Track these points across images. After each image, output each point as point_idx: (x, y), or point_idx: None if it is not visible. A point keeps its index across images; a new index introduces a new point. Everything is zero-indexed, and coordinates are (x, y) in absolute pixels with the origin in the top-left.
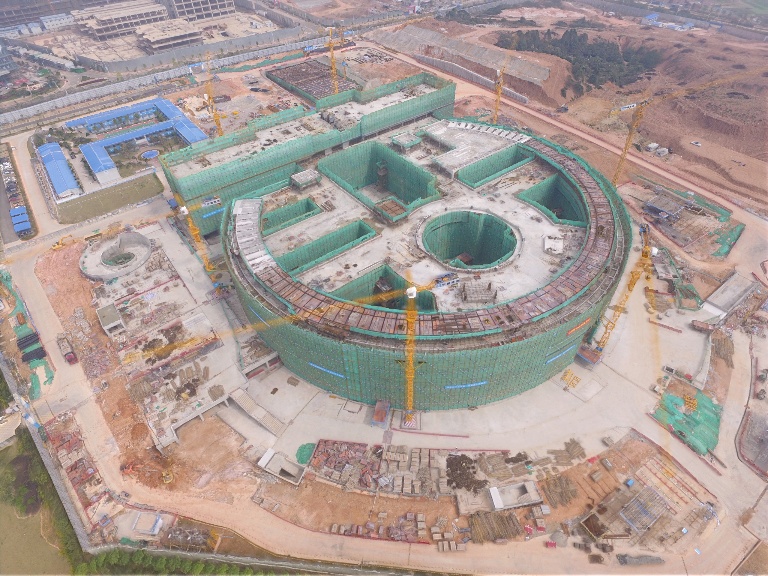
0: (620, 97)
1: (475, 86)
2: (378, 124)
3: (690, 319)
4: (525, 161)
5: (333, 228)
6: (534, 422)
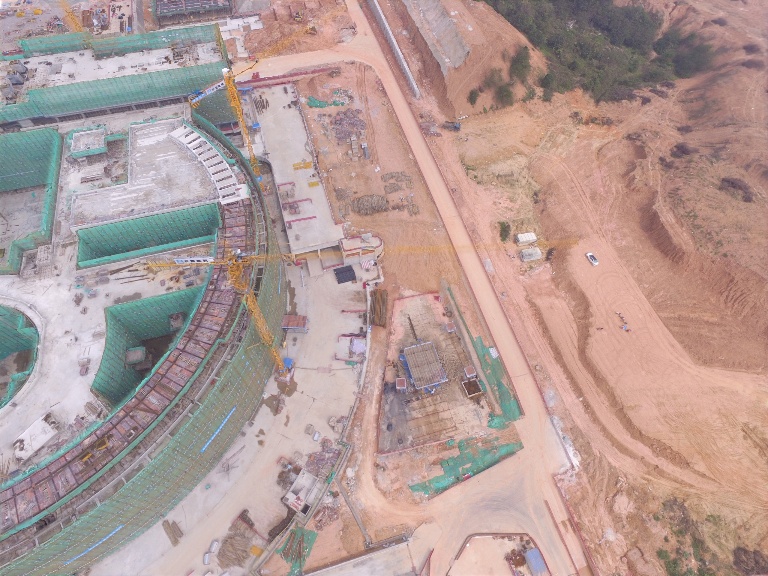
0: (568, 125)
1: (377, 45)
2: (72, 104)
3: None
4: (200, 239)
5: None
6: None
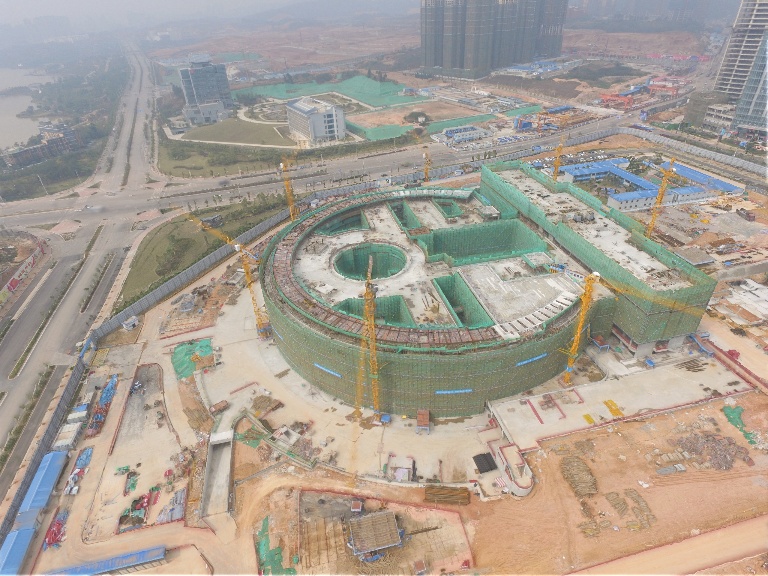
0: None
1: None
2: (568, 243)
3: (232, 411)
4: None
5: (425, 221)
6: (258, 296)
